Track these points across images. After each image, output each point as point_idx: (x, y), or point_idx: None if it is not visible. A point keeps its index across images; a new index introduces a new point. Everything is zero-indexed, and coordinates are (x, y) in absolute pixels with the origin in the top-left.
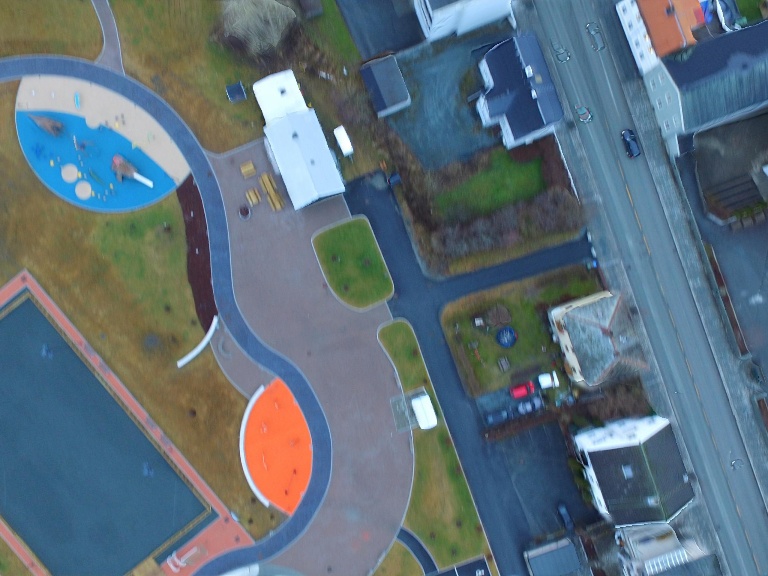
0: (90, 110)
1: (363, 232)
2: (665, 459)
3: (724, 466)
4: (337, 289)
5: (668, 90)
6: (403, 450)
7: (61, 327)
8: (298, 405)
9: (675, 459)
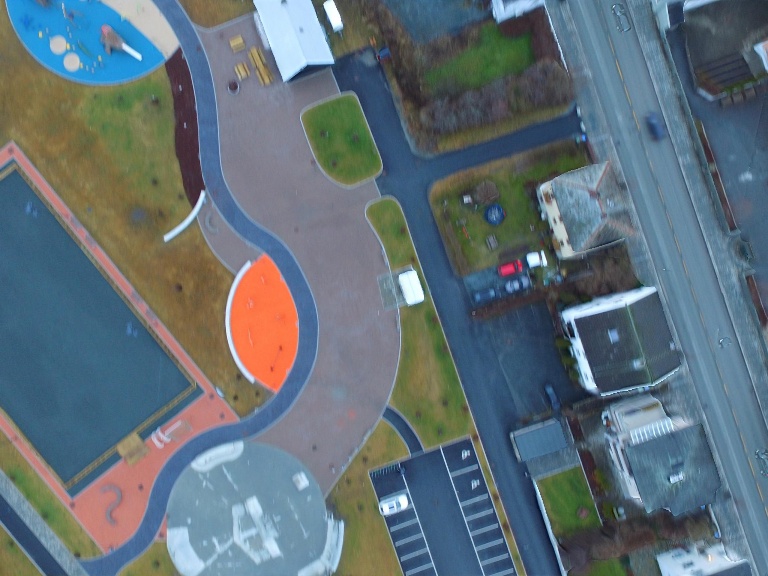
0: None
1: (352, 108)
2: (651, 324)
3: (712, 344)
4: (325, 165)
5: None
6: (390, 328)
7: (48, 200)
8: (285, 282)
9: (662, 326)
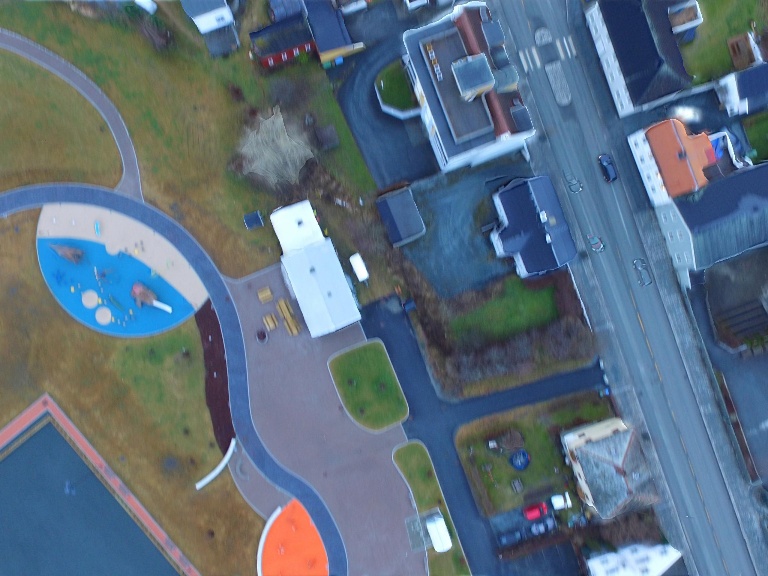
0: (110, 237)
1: (378, 356)
2: None
3: None
4: (353, 412)
5: (680, 228)
6: (418, 570)
7: (82, 450)
8: (314, 525)
9: None
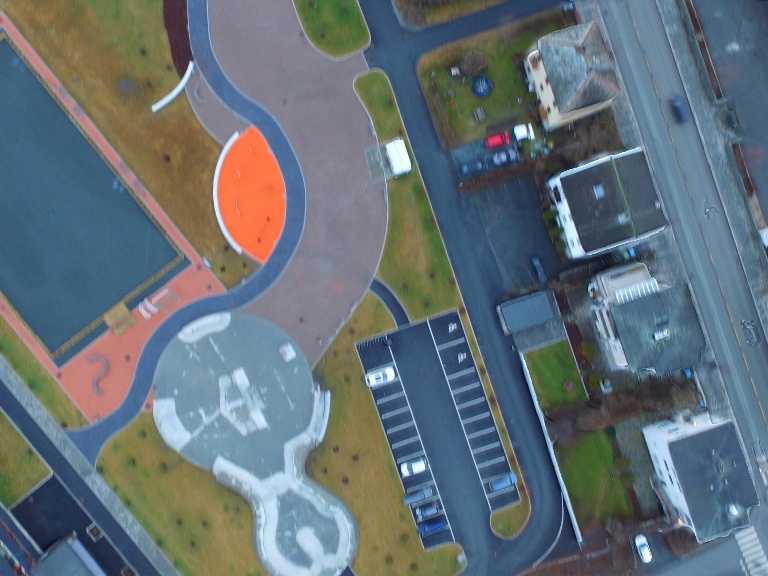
0: None
1: None
2: (637, 181)
3: (698, 214)
4: (313, 37)
5: None
6: (377, 201)
7: (36, 69)
8: (273, 153)
9: (647, 184)
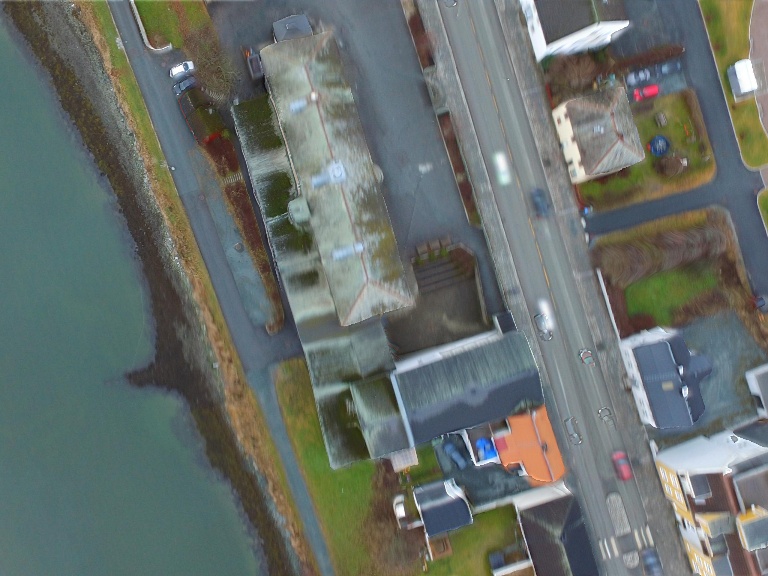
0: None
1: None
2: (565, 7)
3: (465, 1)
4: None
5: None
6: (759, 42)
7: None
8: None
9: (550, 7)
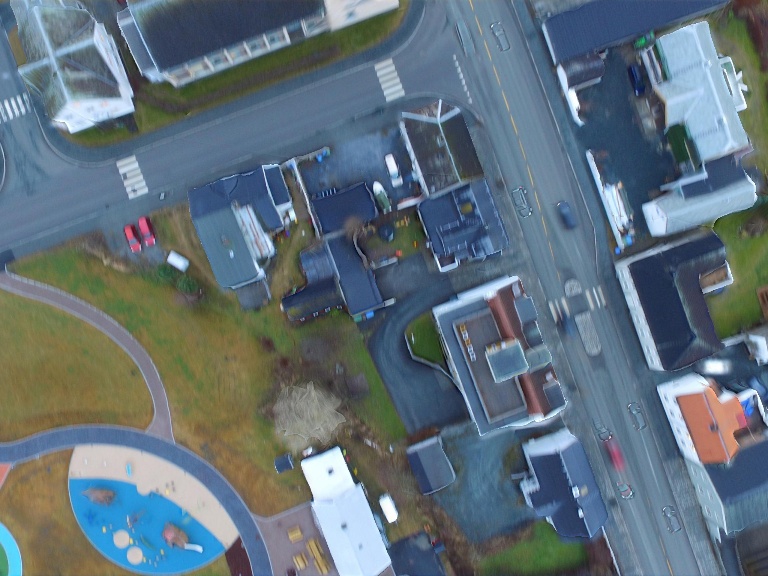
0: (141, 477)
1: None
2: None
3: None
4: None
5: (711, 491)
6: None
7: None
8: None
9: None
